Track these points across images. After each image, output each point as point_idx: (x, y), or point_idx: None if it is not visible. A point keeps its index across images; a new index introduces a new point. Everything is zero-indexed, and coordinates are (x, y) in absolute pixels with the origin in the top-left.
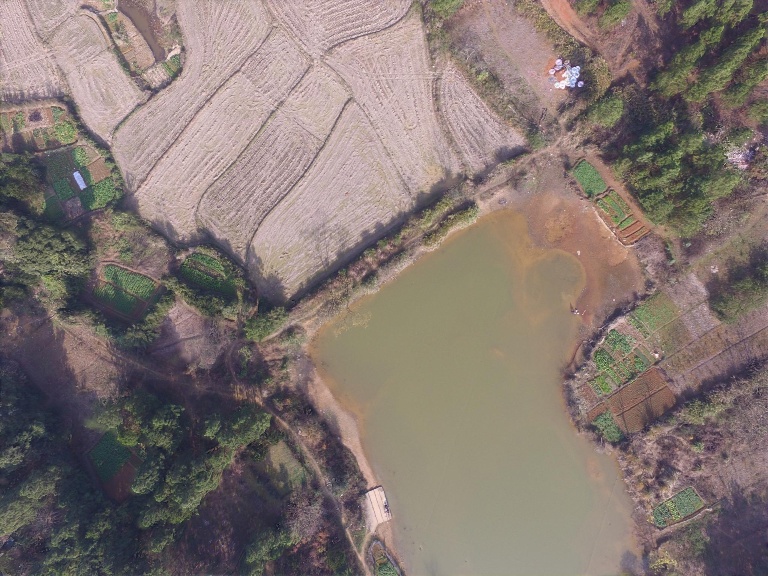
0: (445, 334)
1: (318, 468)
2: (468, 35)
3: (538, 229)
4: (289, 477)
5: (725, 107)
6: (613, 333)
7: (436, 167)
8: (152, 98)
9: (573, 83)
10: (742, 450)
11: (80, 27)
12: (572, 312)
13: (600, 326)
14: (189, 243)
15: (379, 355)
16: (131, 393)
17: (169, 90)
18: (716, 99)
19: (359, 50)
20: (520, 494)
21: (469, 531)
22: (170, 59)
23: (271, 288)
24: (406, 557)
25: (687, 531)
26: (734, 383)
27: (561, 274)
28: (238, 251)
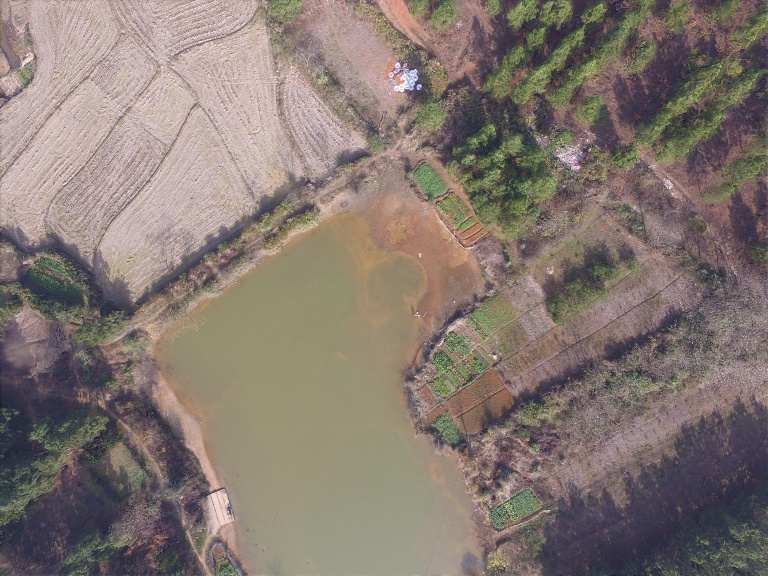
0: (288, 337)
1: (159, 470)
2: (310, 39)
3: (380, 232)
4: (129, 479)
5: (558, 108)
6: (452, 335)
7: (280, 171)
8: (4, 105)
9: (412, 86)
10: (579, 451)
11: None
12: (413, 314)
13: (440, 328)
14: (38, 248)
15: (221, 358)
16: None
17: (20, 97)
18: (544, 101)
19: (204, 56)
20: (362, 496)
21: (311, 533)
22: (24, 67)
23: (117, 292)
24: (249, 559)
25: (525, 533)
26: (568, 384)
27: (403, 276)
28: (86, 256)
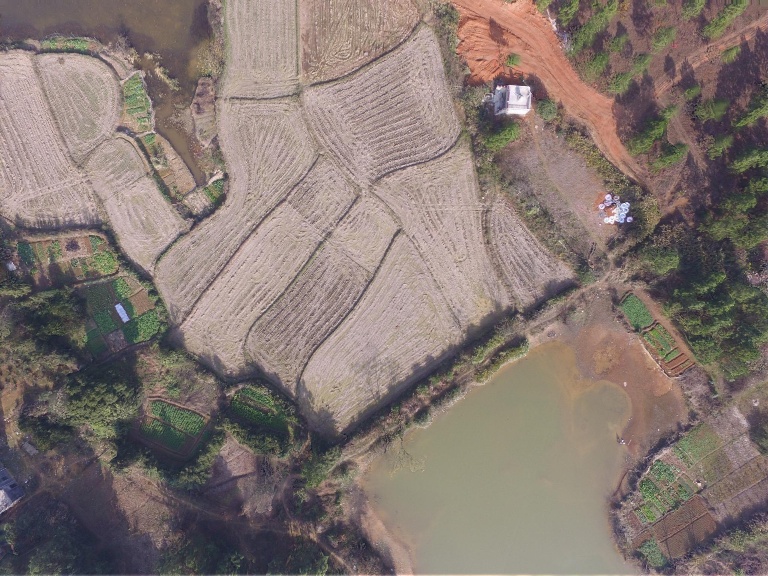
0: (495, 465)
1: None
2: (518, 167)
3: (586, 361)
4: None
5: None
6: (658, 464)
7: (486, 299)
8: (195, 228)
9: (622, 218)
10: None
11: (117, 151)
12: (618, 442)
13: (645, 456)
14: (237, 377)
15: (431, 488)
16: (185, 535)
17: (213, 219)
18: (764, 244)
19: (408, 180)
20: None
21: None
22: (212, 184)
23: (322, 422)
24: None
25: None
26: None
27: (608, 405)
28: (288, 385)
